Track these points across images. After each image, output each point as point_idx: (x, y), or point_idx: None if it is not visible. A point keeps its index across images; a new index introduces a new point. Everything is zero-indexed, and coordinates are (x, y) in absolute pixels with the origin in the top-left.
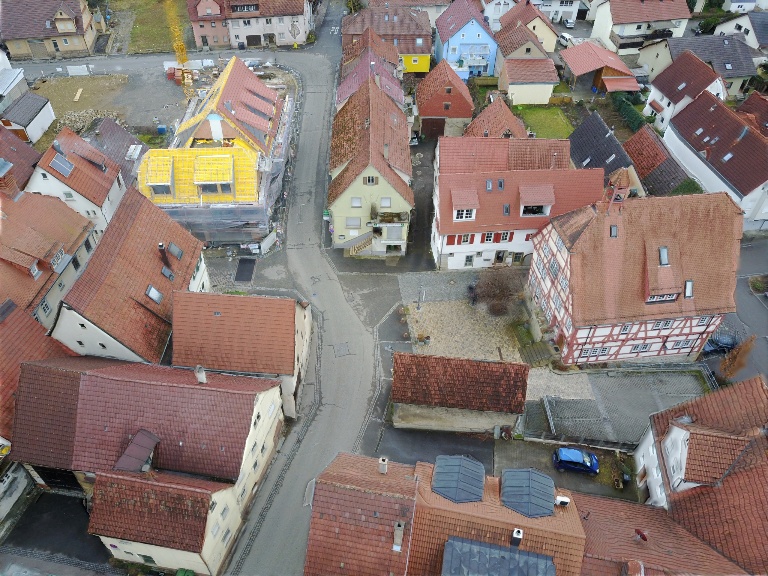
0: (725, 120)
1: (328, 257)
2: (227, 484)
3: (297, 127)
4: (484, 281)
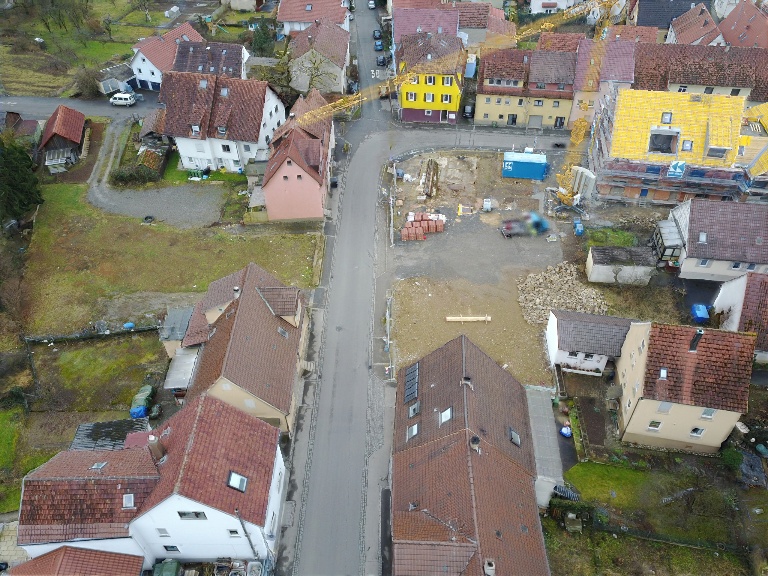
0: None
1: None
2: None
3: None
4: None
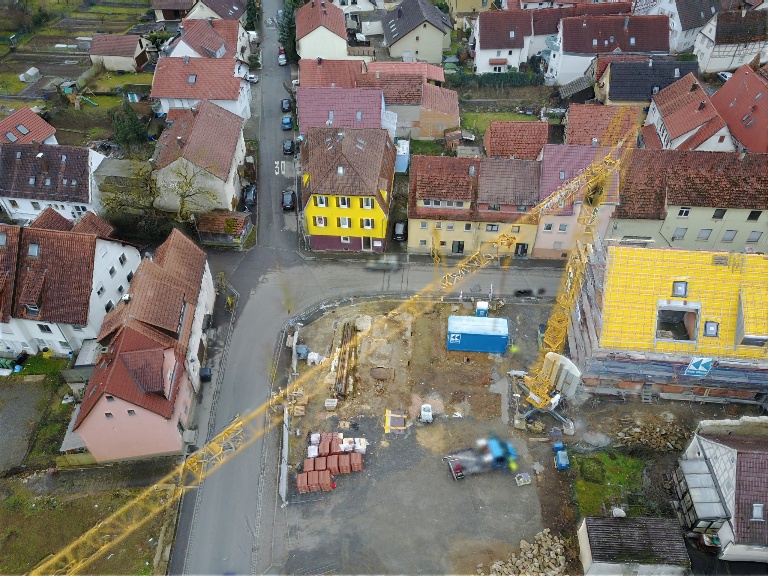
0: (603, 24)
1: None
2: None
3: (518, 299)
4: None
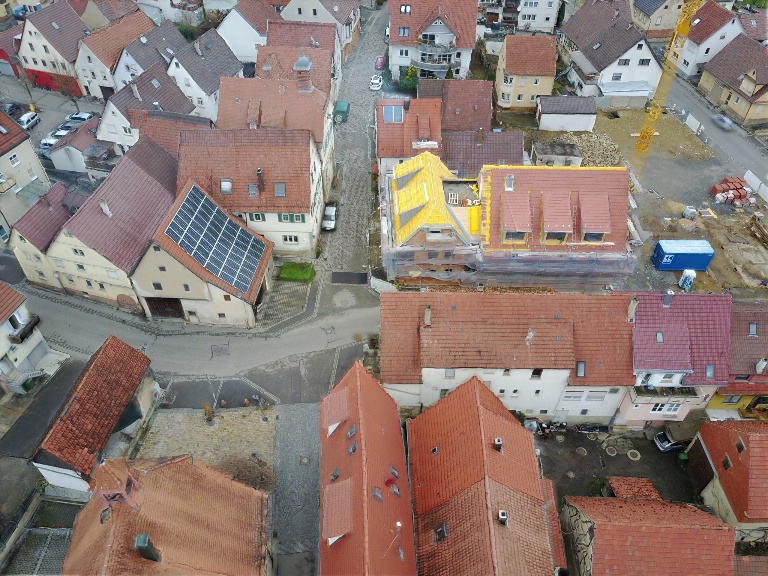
0: None
1: (368, 340)
2: (40, 247)
3: None
4: (303, 500)
